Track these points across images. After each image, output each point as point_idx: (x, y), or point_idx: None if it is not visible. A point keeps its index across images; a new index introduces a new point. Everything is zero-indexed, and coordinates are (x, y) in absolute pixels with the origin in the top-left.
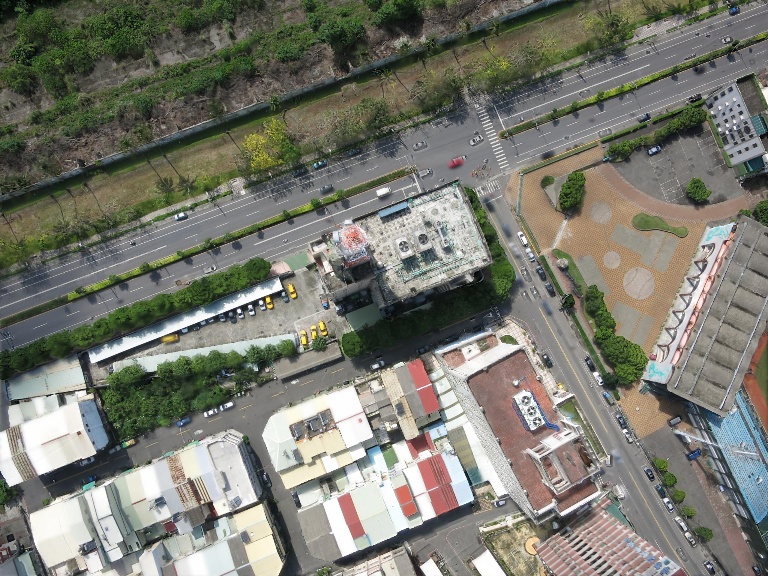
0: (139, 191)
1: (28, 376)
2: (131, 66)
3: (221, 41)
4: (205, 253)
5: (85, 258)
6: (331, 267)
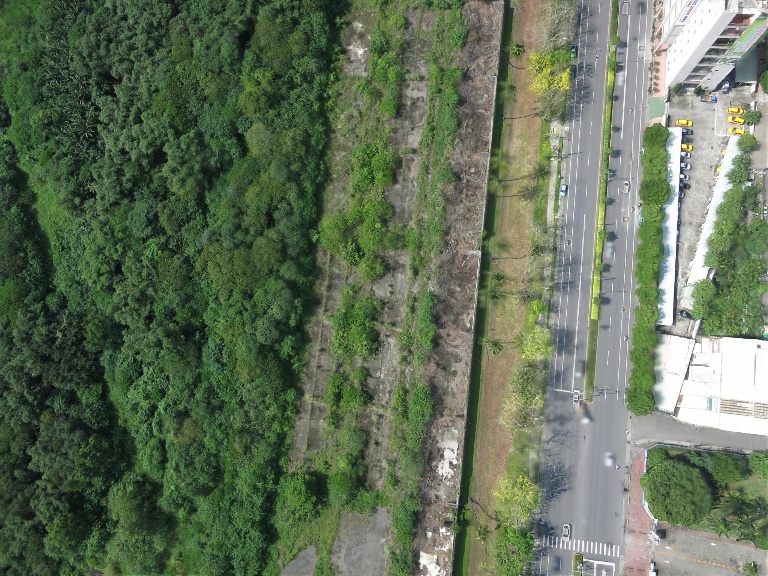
0: (519, 219)
1: (657, 387)
2: (405, 173)
3: (420, 90)
4: (608, 184)
5: (562, 290)
6: (757, 1)
